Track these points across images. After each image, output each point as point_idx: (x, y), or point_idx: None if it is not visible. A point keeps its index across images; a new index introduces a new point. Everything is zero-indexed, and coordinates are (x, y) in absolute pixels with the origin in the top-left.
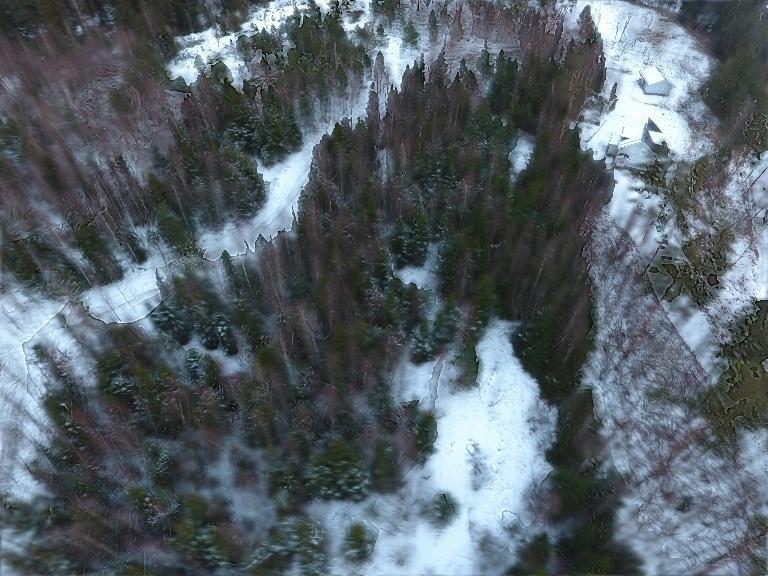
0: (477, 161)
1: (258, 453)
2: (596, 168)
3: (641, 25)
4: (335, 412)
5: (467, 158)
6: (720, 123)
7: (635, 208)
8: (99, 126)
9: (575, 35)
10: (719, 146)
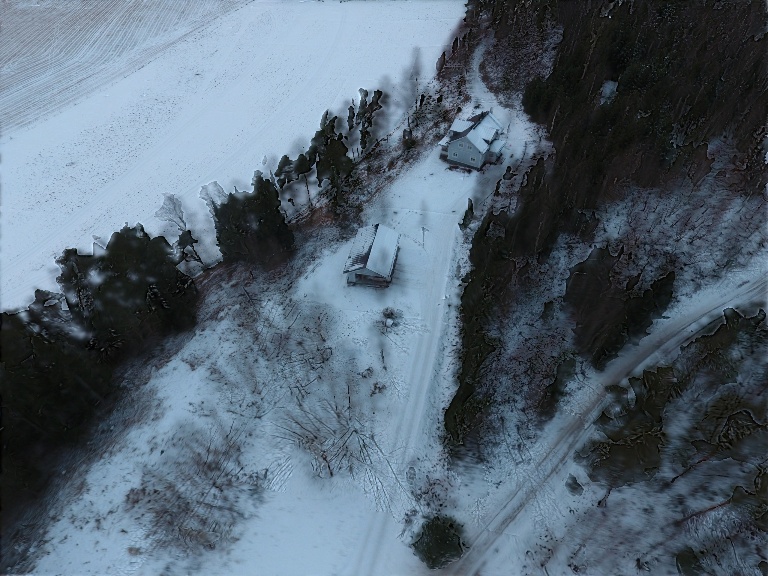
0: None
1: None
2: None
3: None
4: None
5: None
6: None
7: None
8: None
9: (466, 519)
10: (333, 204)
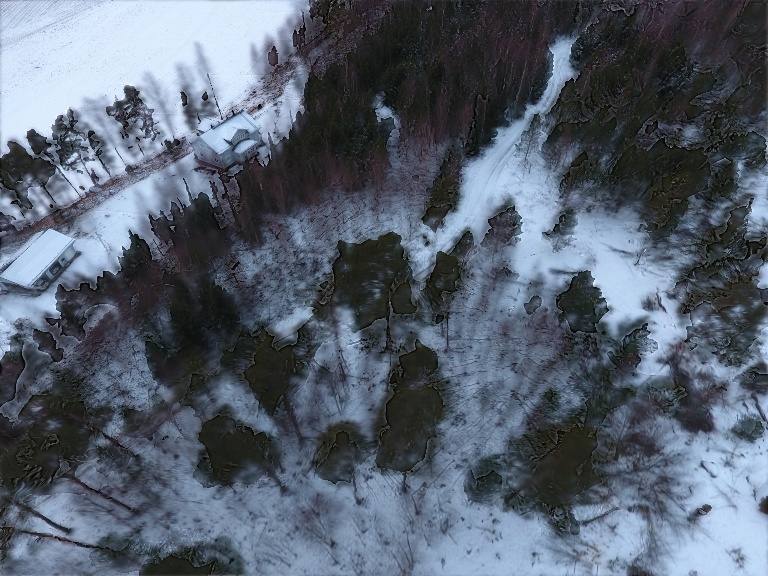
0: None
1: None
2: (319, 81)
3: None
4: None
5: None
6: (3, 243)
7: (277, 118)
8: None
9: None
10: None
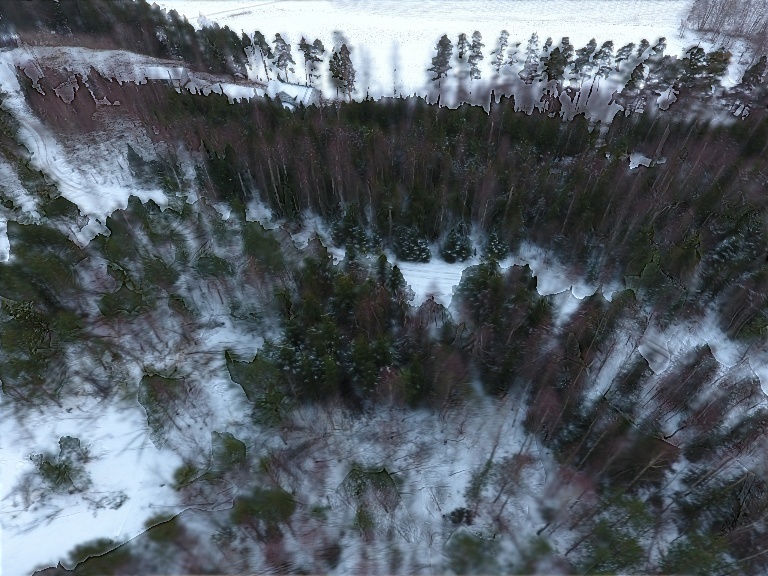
0: (436, 122)
1: (762, 201)
2: None
3: (9, 63)
4: (709, 180)
5: (397, 144)
6: (223, 76)
7: None
8: (432, 529)
9: (7, 100)
10: None
